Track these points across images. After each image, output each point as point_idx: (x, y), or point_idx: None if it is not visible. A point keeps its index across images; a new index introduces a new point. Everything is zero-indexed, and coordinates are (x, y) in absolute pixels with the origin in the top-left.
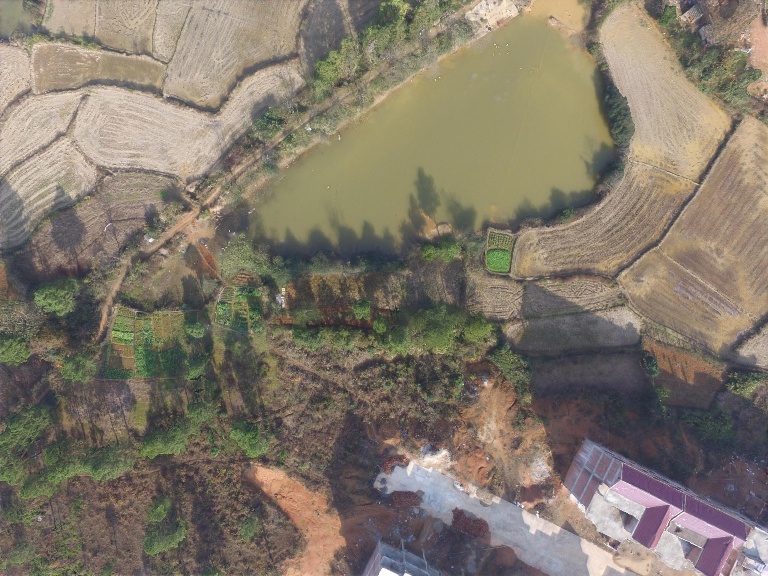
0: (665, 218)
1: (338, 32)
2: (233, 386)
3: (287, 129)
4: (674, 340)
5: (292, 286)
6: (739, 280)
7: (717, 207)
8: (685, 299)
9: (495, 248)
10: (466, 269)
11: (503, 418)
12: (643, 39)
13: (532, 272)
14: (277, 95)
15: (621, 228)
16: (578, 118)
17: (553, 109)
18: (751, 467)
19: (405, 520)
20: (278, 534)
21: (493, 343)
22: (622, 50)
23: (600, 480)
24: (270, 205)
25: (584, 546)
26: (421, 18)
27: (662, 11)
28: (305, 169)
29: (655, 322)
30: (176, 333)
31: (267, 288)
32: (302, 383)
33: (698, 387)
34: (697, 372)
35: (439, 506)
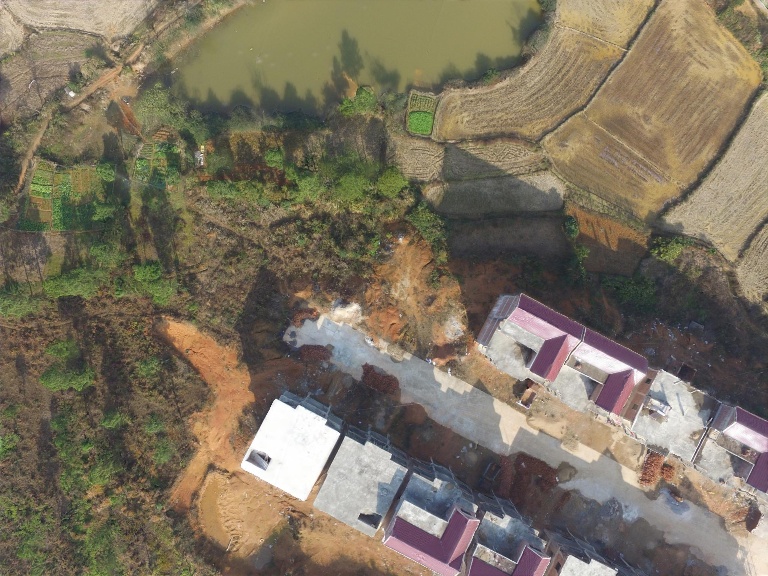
0: (592, 84)
1: None
2: (148, 241)
3: None
4: (598, 206)
5: (211, 144)
6: (667, 147)
7: (645, 73)
8: (610, 165)
9: (417, 110)
10: (386, 129)
11: (418, 276)
12: None
13: (454, 135)
14: None
15: (546, 92)
16: None
17: None
18: (674, 333)
19: (314, 374)
20: (187, 388)
21: (411, 203)
22: None
23: (502, 318)
24: (193, 65)
25: (497, 406)
26: None
27: None
28: (229, 30)
29: (579, 187)
30: (94, 187)
31: (184, 141)
32: (217, 238)
33: (622, 254)
34: (621, 238)
35: (349, 361)
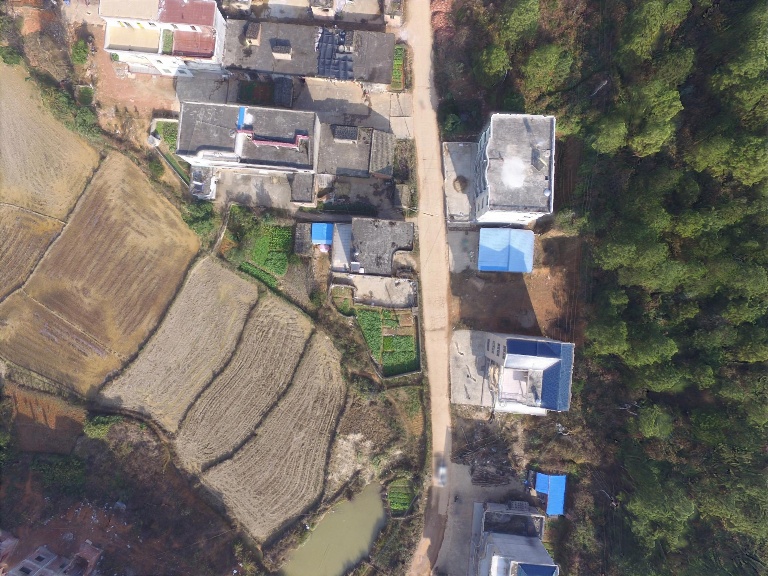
0: (32, 259)
1: None
2: None
3: None
4: (39, 384)
5: None
6: (107, 320)
7: (83, 246)
8: (50, 341)
9: None
10: None
11: None
12: (9, 79)
13: None
14: None
15: None
16: None
17: None
18: (98, 514)
19: None
20: None
21: None
22: None
23: None
24: None
25: None
26: None
27: None
28: None
29: (19, 366)
30: None
31: None
32: None
33: (60, 432)
34: (59, 416)
35: None
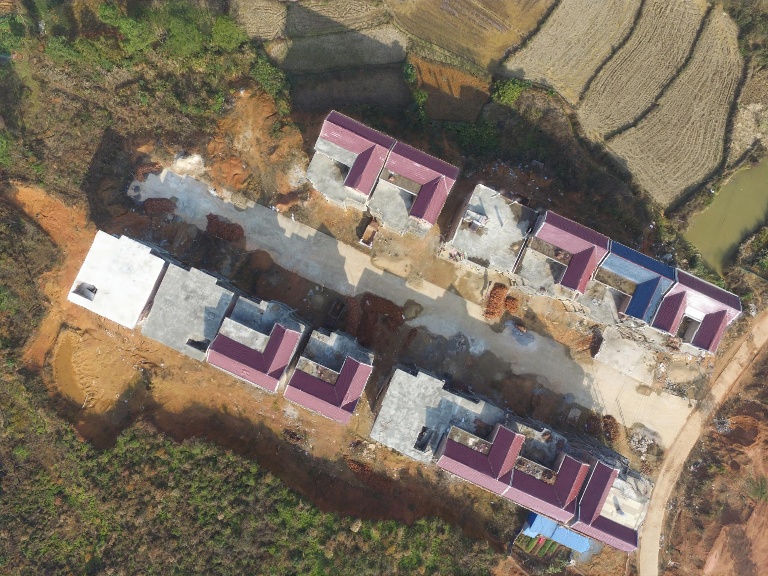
0: None
1: None
2: None
3: None
4: (441, 57)
5: (55, 13)
6: None
7: None
8: (451, 16)
9: None
10: None
11: (260, 127)
12: None
13: None
14: None
15: None
16: None
17: None
18: (515, 172)
19: (158, 226)
20: (37, 250)
21: (254, 59)
22: None
23: None
24: None
25: (341, 248)
26: None
27: None
28: None
29: (421, 39)
30: None
31: (24, 7)
32: (62, 103)
33: (465, 101)
34: (464, 86)
35: (193, 212)
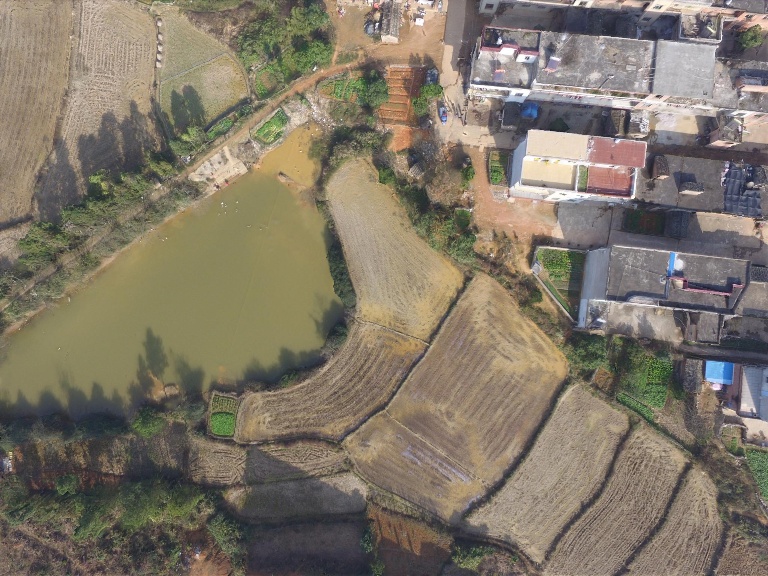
0: (394, 379)
1: (71, 193)
2: None
3: (13, 295)
4: (402, 507)
5: (19, 450)
6: (471, 444)
7: (448, 368)
8: (413, 465)
9: (219, 411)
10: (187, 434)
11: None
12: (372, 195)
13: (256, 436)
14: (11, 257)
15: (347, 391)
16: (308, 275)
17: (283, 267)
18: None
19: None
20: None
21: (211, 511)
22: (350, 207)
23: None
24: (3, 367)
25: None
26: (121, 194)
27: (390, 166)
28: (36, 331)
29: (382, 488)
30: None
31: None
32: (23, 549)
33: (425, 558)
34: (424, 542)
35: None
